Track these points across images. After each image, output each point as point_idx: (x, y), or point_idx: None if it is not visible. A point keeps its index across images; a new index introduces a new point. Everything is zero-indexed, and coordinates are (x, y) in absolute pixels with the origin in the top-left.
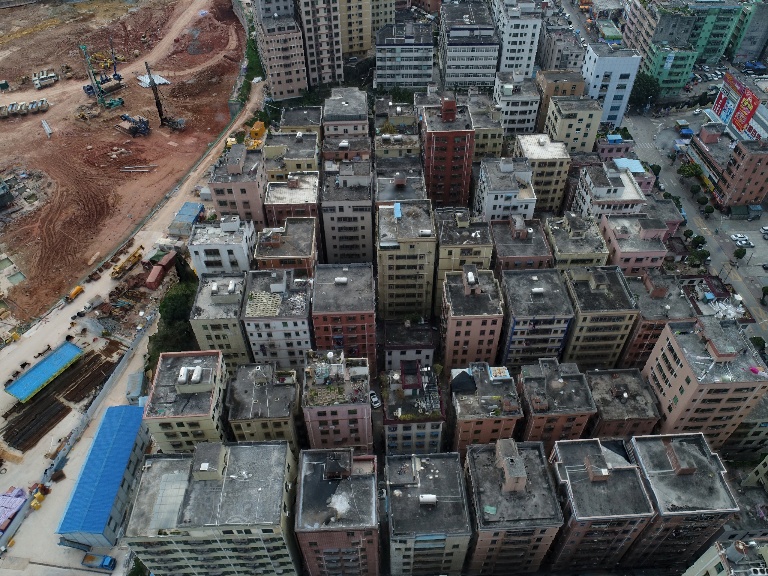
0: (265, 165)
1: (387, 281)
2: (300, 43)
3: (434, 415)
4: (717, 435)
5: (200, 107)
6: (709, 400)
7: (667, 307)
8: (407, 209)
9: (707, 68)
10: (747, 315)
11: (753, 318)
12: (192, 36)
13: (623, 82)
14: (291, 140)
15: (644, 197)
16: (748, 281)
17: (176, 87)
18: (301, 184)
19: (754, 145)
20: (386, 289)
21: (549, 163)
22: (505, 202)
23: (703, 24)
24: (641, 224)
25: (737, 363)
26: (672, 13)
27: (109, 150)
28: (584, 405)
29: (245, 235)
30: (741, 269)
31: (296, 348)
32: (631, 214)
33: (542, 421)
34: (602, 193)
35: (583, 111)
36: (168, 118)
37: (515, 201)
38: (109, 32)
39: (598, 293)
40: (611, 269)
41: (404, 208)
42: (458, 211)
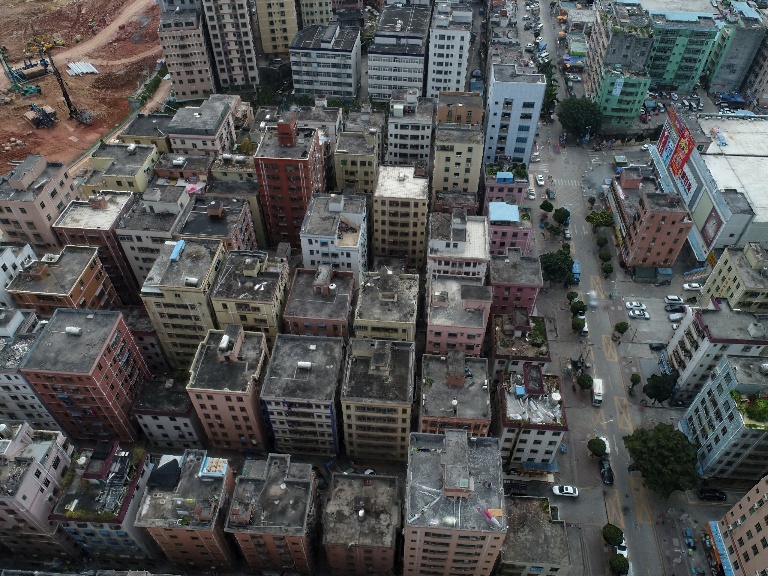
0: (71, 181)
1: (164, 329)
2: (199, 41)
3: (106, 516)
4: (471, 575)
5: (118, 101)
6: (433, 542)
7: (453, 402)
8: (192, 249)
9: (675, 96)
10: (561, 420)
11: (565, 425)
12: (140, 24)
13: (527, 111)
14: (124, 152)
15: (488, 256)
16: (624, 362)
17: (101, 77)
18: (108, 205)
19: (661, 199)
20: (166, 337)
21: (401, 203)
22: (322, 248)
23: (673, 46)
24: (462, 292)
25: (475, 500)
26: (626, 32)
27: (5, 141)
28: (295, 523)
29: (1, 263)
30: (622, 346)
31: (24, 402)
32: (463, 276)
33: (245, 535)
34: (440, 246)
35: (460, 144)
36: (81, 110)
37: (333, 247)
38: (61, 14)
39: (375, 375)
40: (406, 345)
41: (189, 247)
42: (256, 255)
